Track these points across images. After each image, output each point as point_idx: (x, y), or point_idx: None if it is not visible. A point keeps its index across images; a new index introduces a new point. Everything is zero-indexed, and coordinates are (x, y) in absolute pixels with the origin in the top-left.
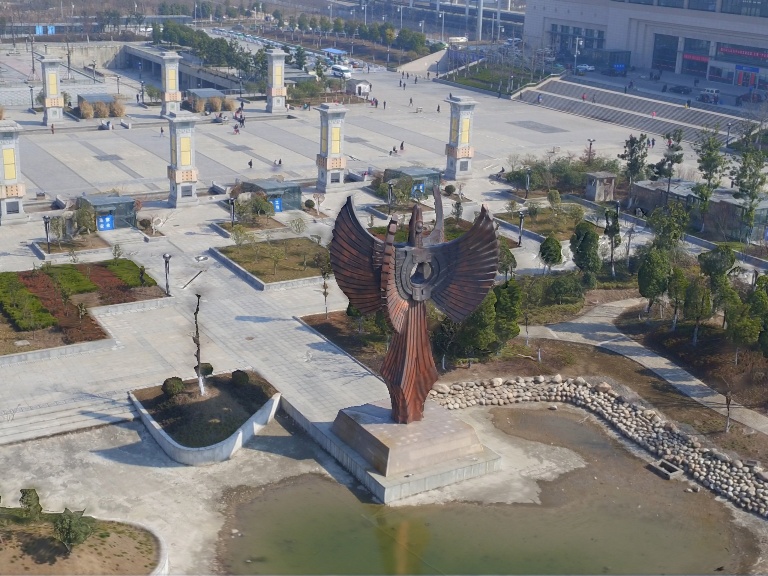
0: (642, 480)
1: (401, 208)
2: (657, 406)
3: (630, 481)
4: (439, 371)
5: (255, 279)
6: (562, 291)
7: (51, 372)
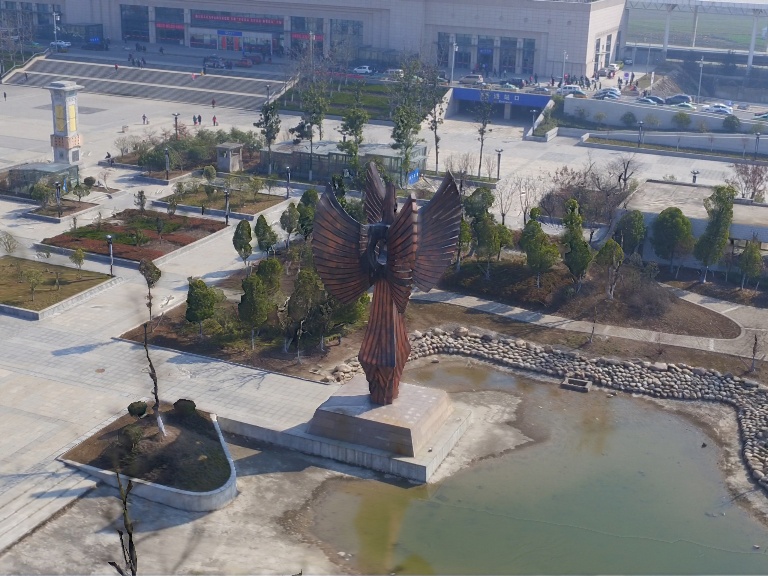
0: (572, 398)
1: (60, 209)
2: (519, 336)
3: (566, 402)
4: (322, 353)
5: (19, 309)
6: None
7: None
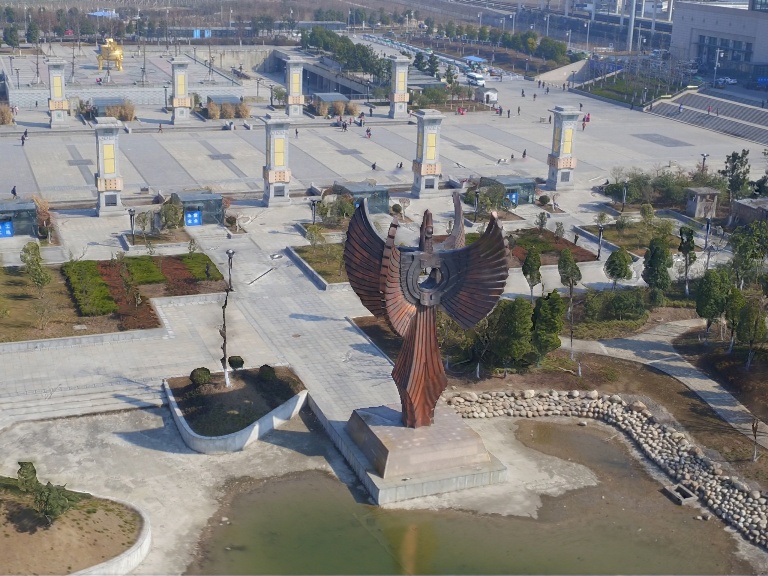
0: (652, 503)
1: None
2: (689, 429)
3: (639, 503)
4: (472, 379)
5: (320, 279)
6: (622, 306)
7: (99, 356)
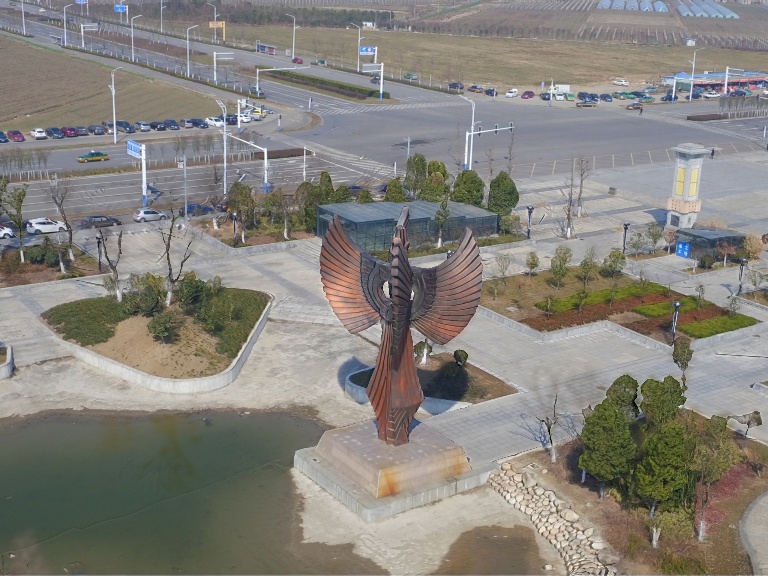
0: None
1: None
2: None
3: None
4: (573, 478)
5: None
6: None
7: (473, 327)
